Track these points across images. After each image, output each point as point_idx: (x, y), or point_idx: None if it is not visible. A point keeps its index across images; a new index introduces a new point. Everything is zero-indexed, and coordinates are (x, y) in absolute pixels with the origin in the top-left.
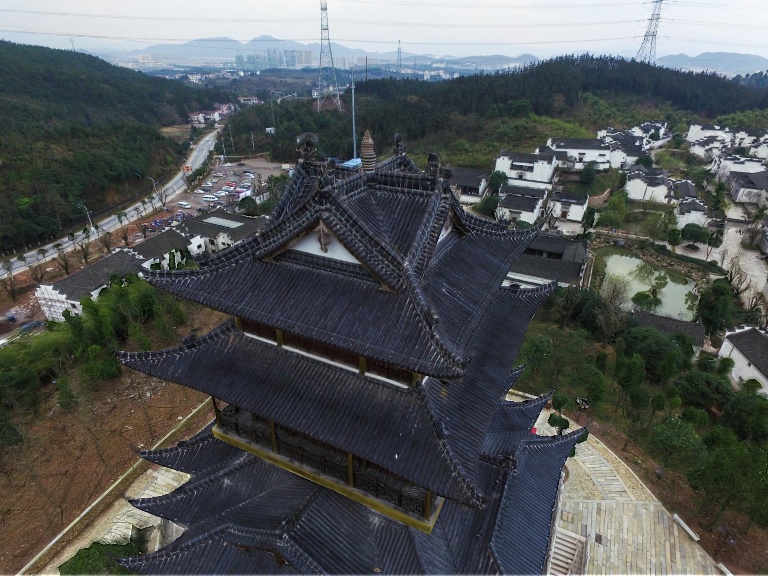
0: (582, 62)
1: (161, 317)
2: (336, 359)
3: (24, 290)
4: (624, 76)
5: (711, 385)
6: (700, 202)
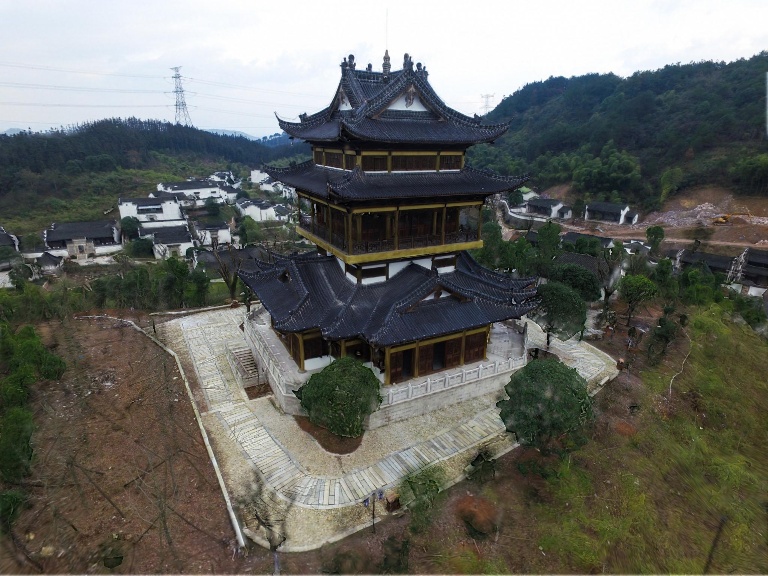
0: (132, 125)
1: (8, 338)
2: (423, 169)
3: None
4: (178, 136)
5: None
6: (303, 212)
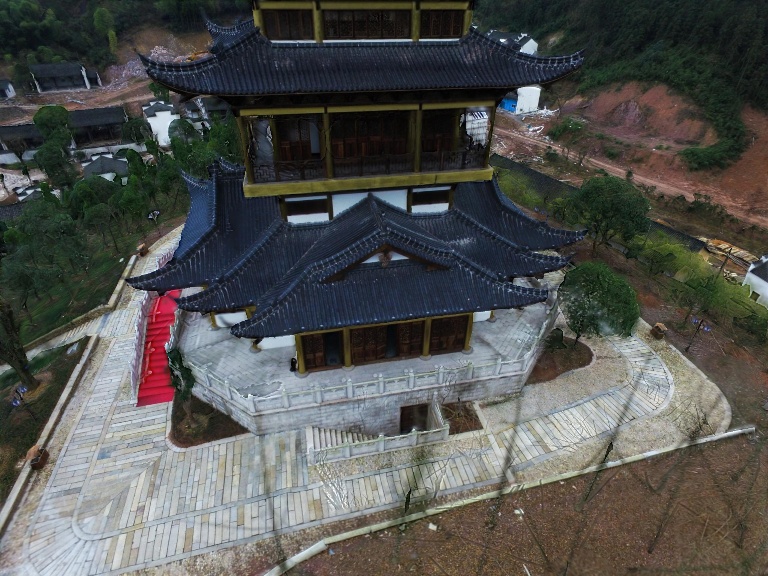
0: None
1: None
2: None
3: None
4: None
5: None
6: None
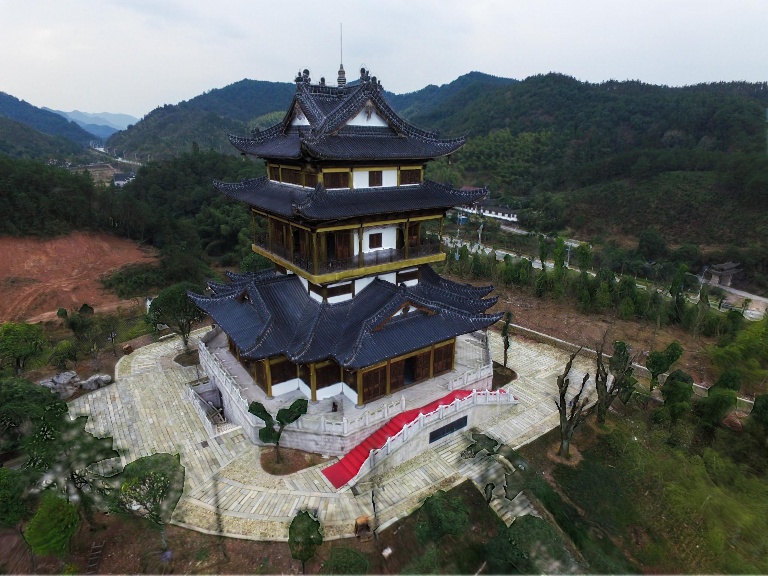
0: None
1: None
2: None
3: None
4: None
5: None
6: None
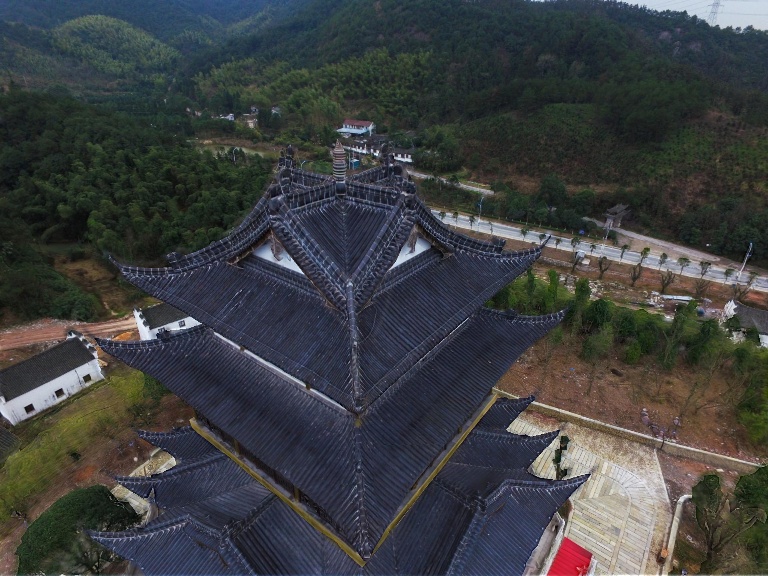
0: None
1: (604, 336)
2: None
3: (753, 306)
4: None
5: None
6: None
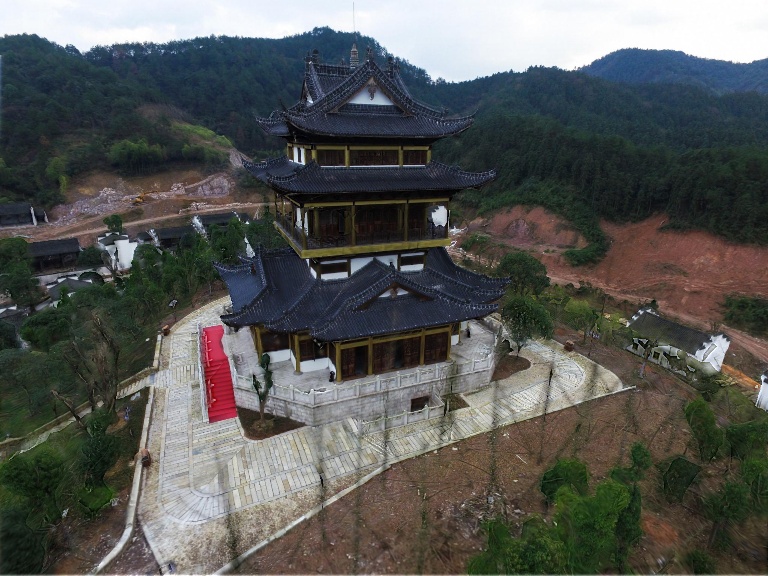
0: None
1: None
2: None
3: None
4: None
5: (55, 312)
6: None
